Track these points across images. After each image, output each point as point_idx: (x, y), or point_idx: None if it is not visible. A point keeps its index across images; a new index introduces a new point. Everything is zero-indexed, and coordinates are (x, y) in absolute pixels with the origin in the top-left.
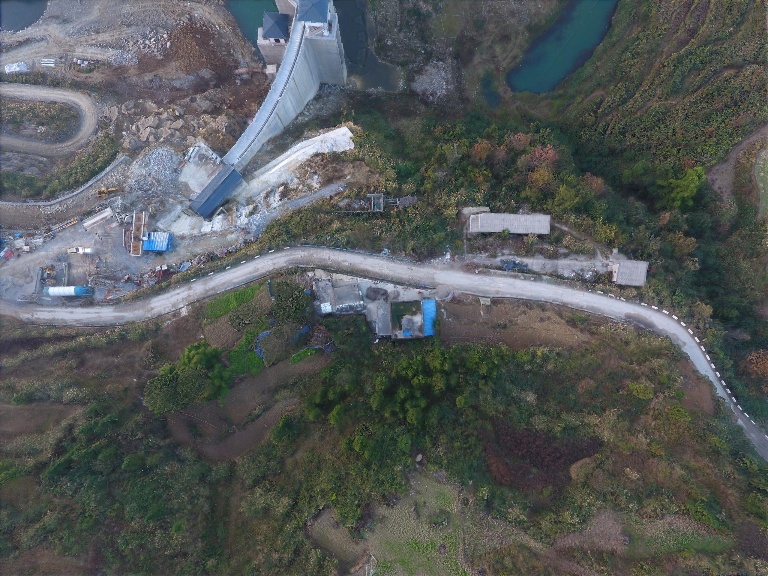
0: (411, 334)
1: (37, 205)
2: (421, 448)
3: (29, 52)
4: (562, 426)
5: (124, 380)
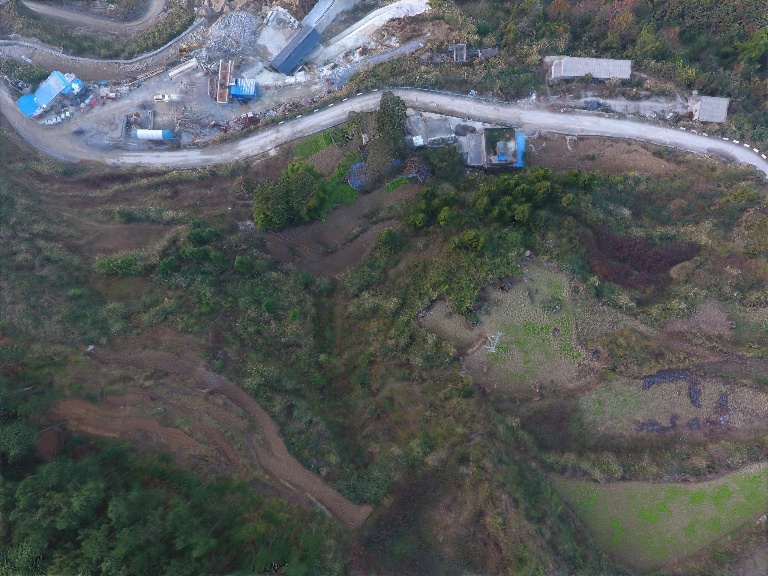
0: (505, 159)
1: (117, 63)
2: (529, 244)
3: None
4: (661, 231)
5: (219, 208)
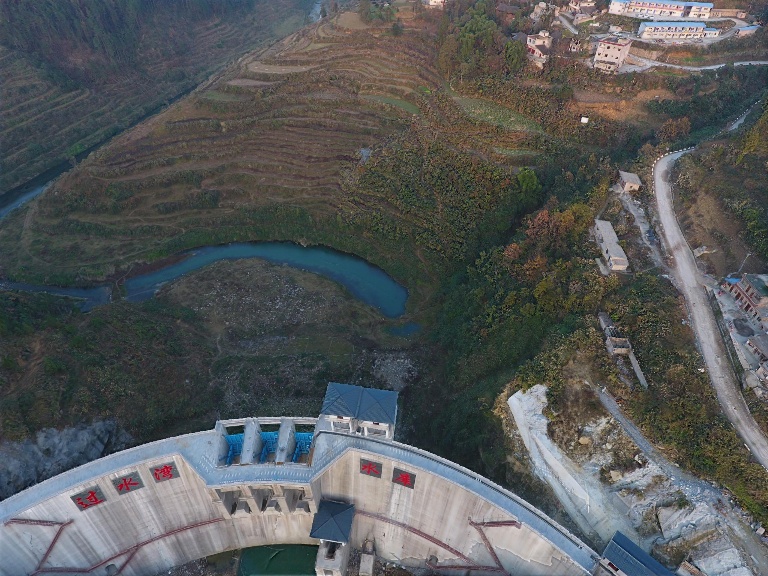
0: None
1: None
2: None
3: None
4: None
5: None
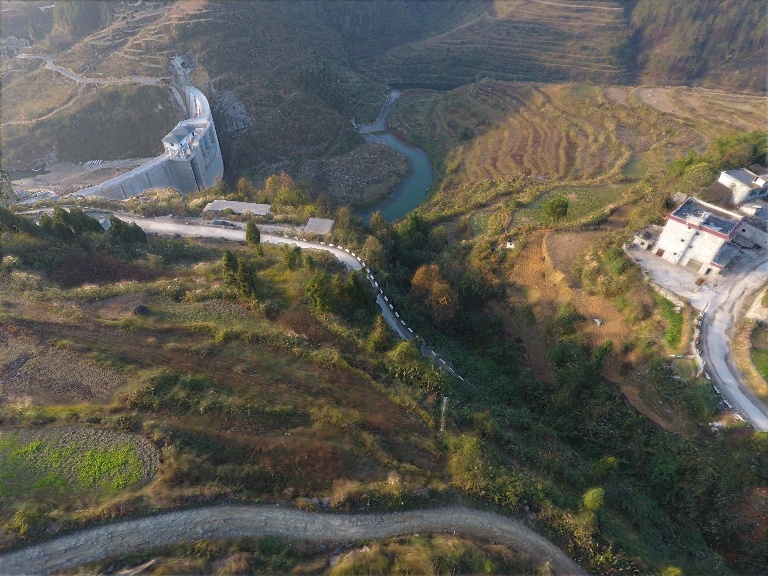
0: None
1: None
2: None
3: None
4: (158, 257)
5: None
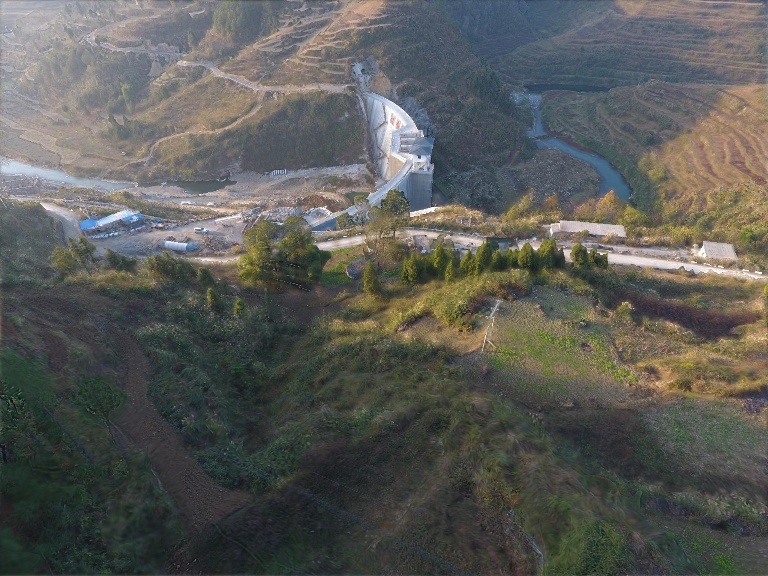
0: None
1: None
2: (537, 281)
3: (202, 199)
4: (700, 295)
5: None
